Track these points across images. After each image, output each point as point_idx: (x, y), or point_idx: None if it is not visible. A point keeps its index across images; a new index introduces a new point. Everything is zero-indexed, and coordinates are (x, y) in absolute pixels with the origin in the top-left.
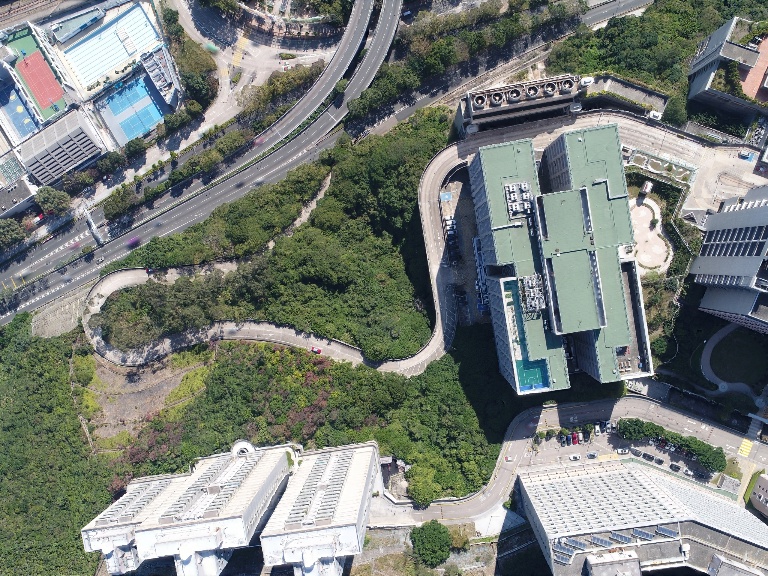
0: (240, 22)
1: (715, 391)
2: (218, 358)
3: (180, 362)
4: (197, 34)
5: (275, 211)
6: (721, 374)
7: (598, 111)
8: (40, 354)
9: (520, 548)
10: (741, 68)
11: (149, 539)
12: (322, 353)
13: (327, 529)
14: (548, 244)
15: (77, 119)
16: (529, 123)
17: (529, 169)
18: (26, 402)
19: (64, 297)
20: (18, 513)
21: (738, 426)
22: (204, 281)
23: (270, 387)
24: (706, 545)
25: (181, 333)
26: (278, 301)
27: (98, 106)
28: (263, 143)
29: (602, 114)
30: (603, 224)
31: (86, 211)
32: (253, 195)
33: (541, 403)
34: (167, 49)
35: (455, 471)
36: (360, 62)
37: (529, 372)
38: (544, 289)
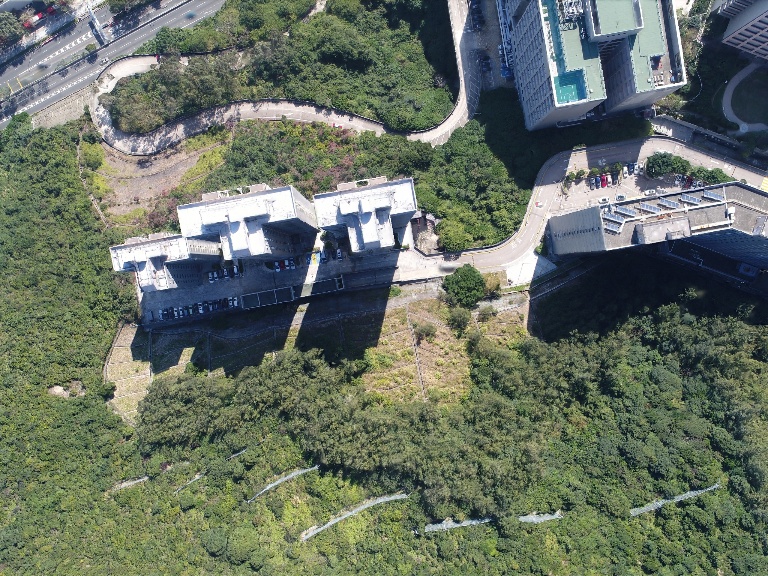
0: None
1: (736, 132)
2: (236, 135)
3: (195, 144)
4: None
5: (289, 2)
6: (742, 115)
7: None
8: (44, 142)
9: (553, 289)
10: None
11: (192, 215)
12: None
13: (381, 187)
14: None
15: None
16: None
17: None
18: (30, 189)
19: None
20: (27, 286)
21: (758, 166)
22: None
23: (293, 155)
24: (750, 208)
25: (195, 117)
26: (297, 78)
27: None
28: None
29: None
30: None
31: (89, 7)
32: None
33: (570, 148)
34: None
35: (485, 223)
36: None
37: (565, 88)
38: None
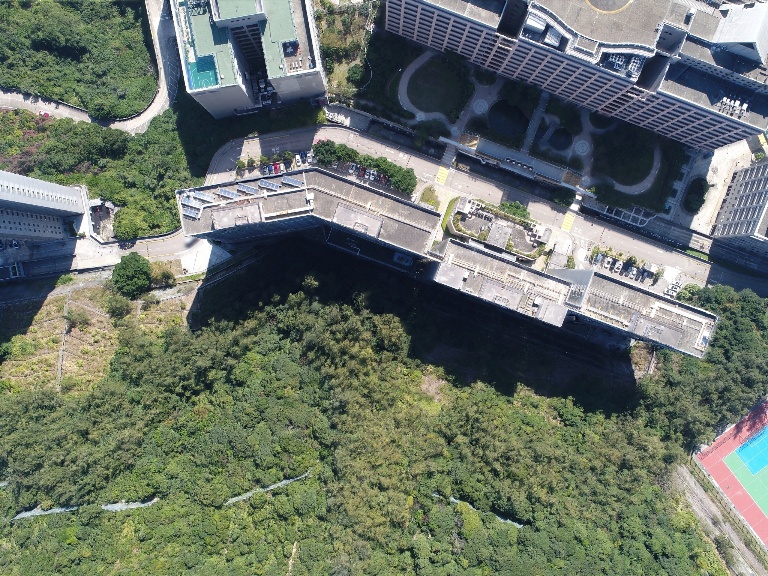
0: None
1: (413, 121)
2: None
3: None
4: None
5: None
6: (418, 104)
7: None
8: None
9: (221, 278)
10: None
11: None
12: None
13: None
14: None
15: None
16: None
17: None
18: None
19: None
20: None
21: (435, 155)
22: None
23: None
24: (331, 195)
25: None
26: (4, 65)
27: None
28: None
29: None
30: None
31: None
32: None
33: (245, 136)
34: None
35: (164, 211)
36: None
37: (203, 74)
38: None
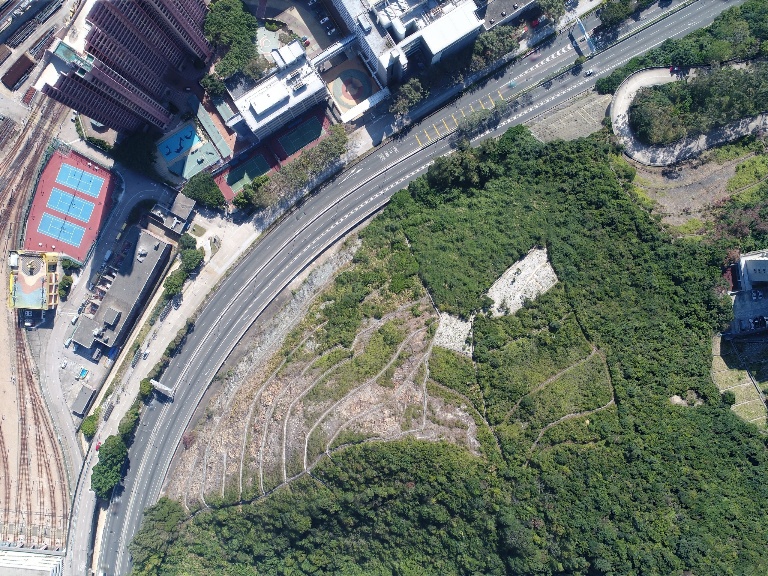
0: None
1: None
2: None
3: (727, 154)
4: None
5: None
6: None
7: None
8: (570, 155)
9: None
10: None
11: None
12: None
13: None
14: None
15: None
16: None
17: None
18: (567, 201)
19: (552, 111)
20: (612, 298)
21: None
22: None
23: None
24: None
25: (719, 128)
26: None
27: None
28: None
29: None
30: None
31: (579, 20)
32: None
33: None
34: None
35: None
36: None
37: None
38: None
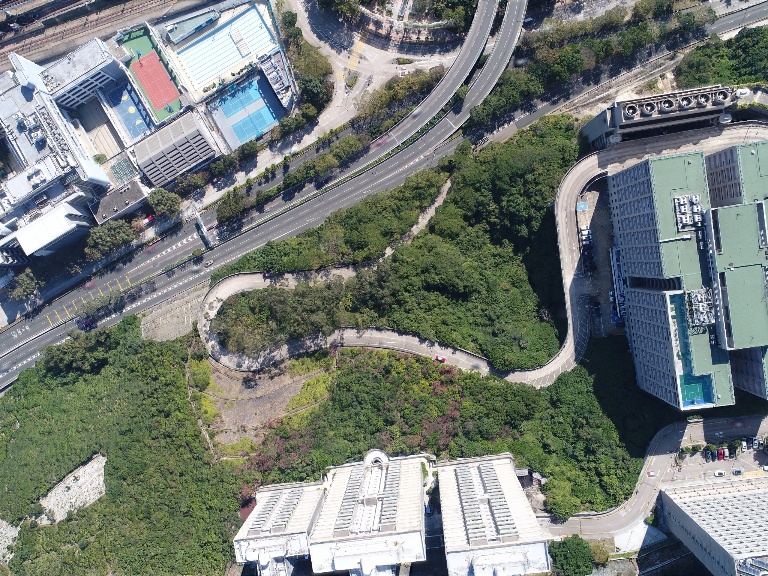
0: (357, 26)
1: None
2: (341, 365)
3: (299, 368)
4: (313, 37)
5: (392, 217)
6: None
7: (747, 123)
8: (155, 358)
9: (663, 565)
10: None
11: (324, 552)
12: (446, 362)
13: (514, 546)
14: (722, 258)
15: (194, 121)
16: (674, 134)
17: (699, 181)
18: (141, 406)
19: (172, 300)
20: (141, 519)
21: None
22: (324, 287)
23: (398, 396)
24: None
25: (299, 339)
26: (402, 309)
27: (210, 108)
28: (379, 148)
29: (751, 126)
30: None
31: (197, 214)
32: (371, 201)
33: (685, 418)
34: (283, 52)
35: (593, 485)
36: (478, 68)
37: (690, 387)
38: (713, 303)
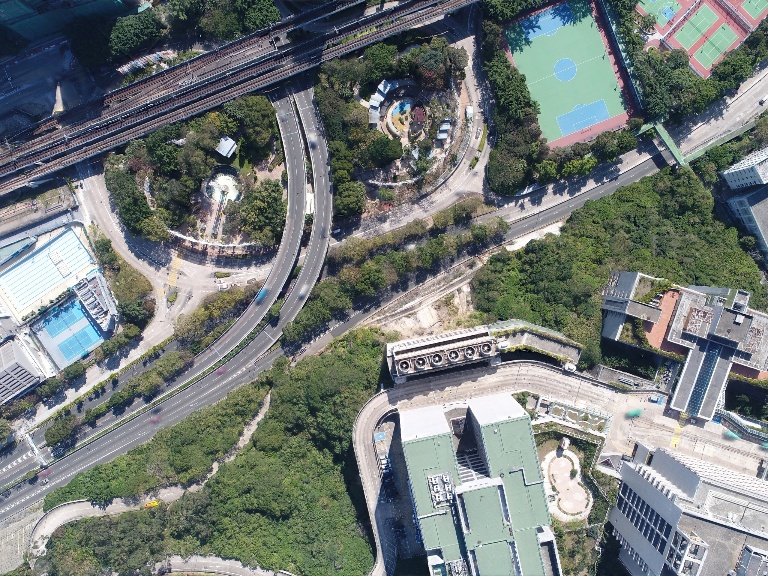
0: (173, 243)
1: None
2: None
3: None
4: (131, 256)
5: (217, 433)
6: None
7: (517, 362)
8: None
9: None
10: (646, 321)
11: None
12: None
13: None
14: (470, 537)
15: (13, 353)
16: (454, 373)
17: (450, 460)
18: None
19: (9, 521)
20: None
21: None
22: (149, 515)
23: None
24: None
25: None
26: (223, 535)
27: (34, 329)
28: (202, 362)
29: (521, 364)
30: (522, 508)
31: (27, 436)
32: (194, 419)
33: None
34: (101, 273)
35: None
36: (294, 278)
37: None
38: (470, 574)
